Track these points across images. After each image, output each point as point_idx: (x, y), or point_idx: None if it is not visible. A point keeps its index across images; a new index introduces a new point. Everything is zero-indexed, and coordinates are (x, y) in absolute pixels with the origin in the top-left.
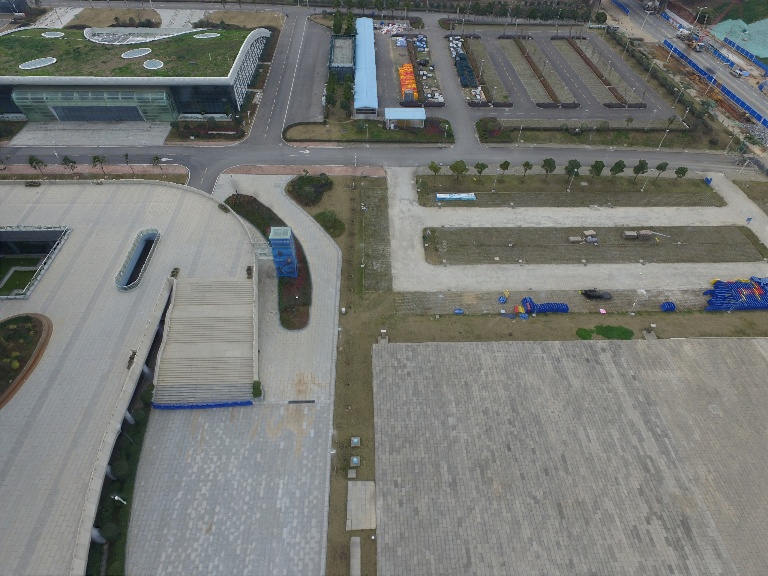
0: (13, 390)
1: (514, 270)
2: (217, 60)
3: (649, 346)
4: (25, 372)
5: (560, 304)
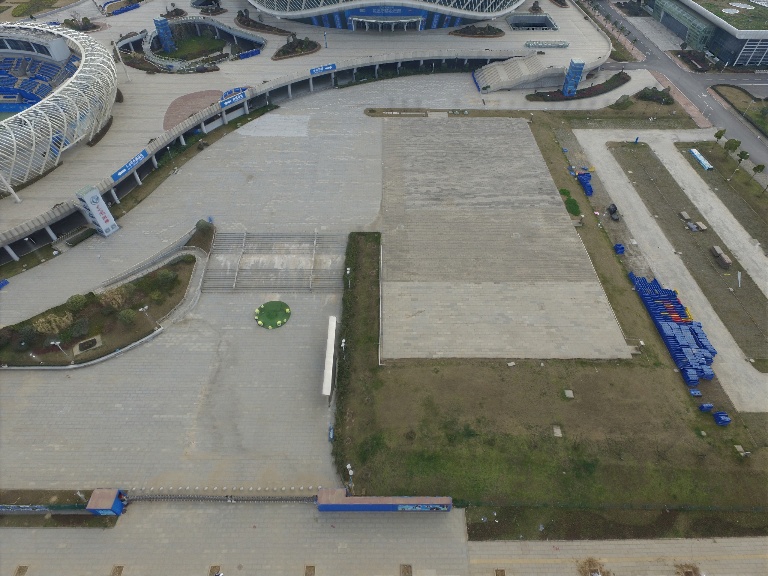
0: (468, 36)
1: (621, 178)
2: (766, 27)
3: (565, 219)
4: (476, 36)
5: (591, 188)
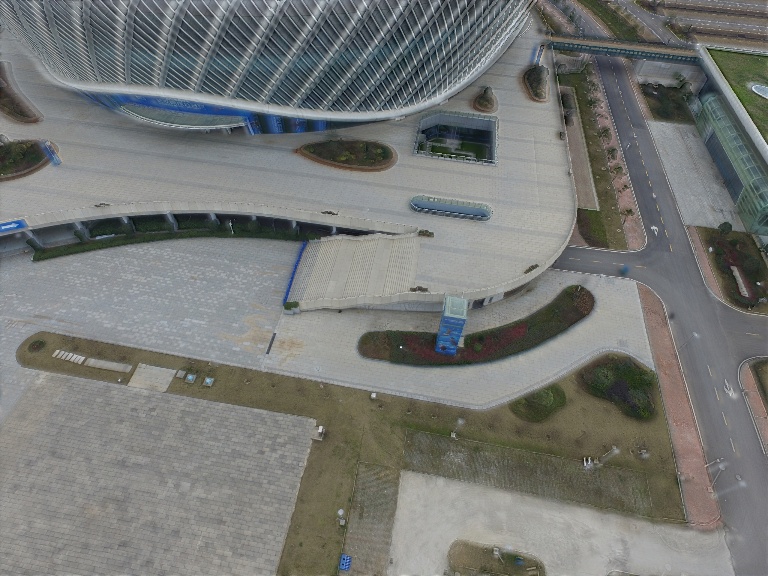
0: (325, 162)
1: None
2: None
3: None
4: (339, 165)
5: None
